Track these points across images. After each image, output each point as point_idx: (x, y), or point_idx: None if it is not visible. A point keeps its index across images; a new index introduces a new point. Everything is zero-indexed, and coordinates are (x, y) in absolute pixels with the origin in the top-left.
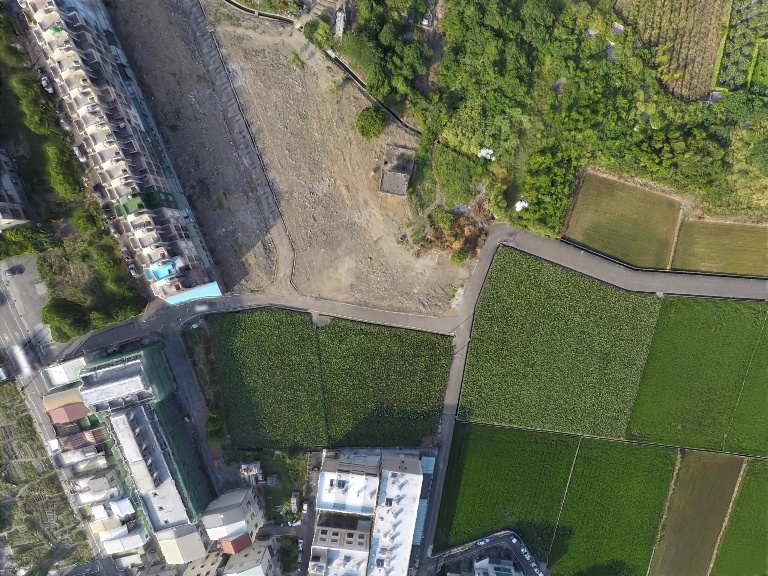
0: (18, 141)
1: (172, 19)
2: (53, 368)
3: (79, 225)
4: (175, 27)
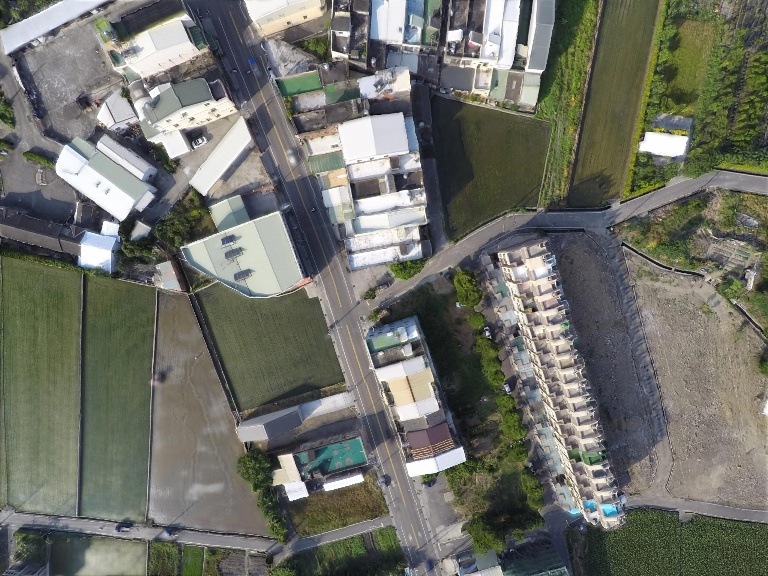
0: (451, 377)
1: (601, 277)
2: (471, 574)
3: (518, 458)
4: (605, 284)
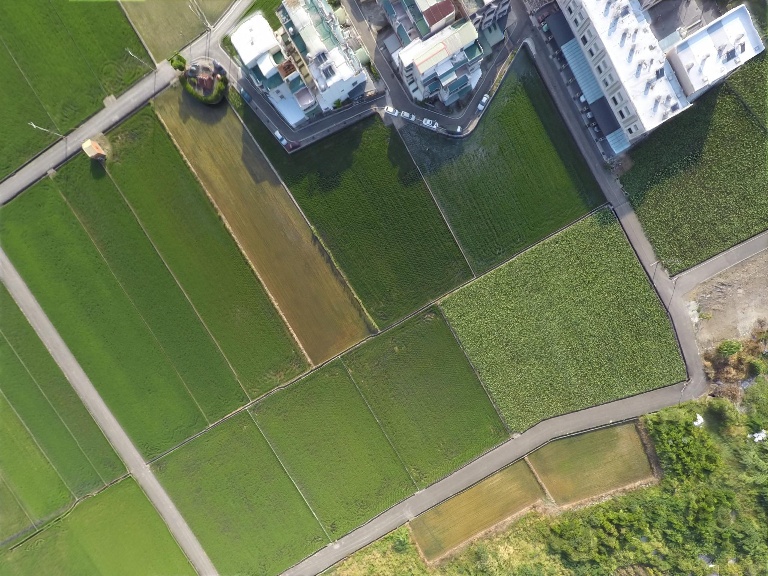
0: None
1: None
2: None
3: None
4: None
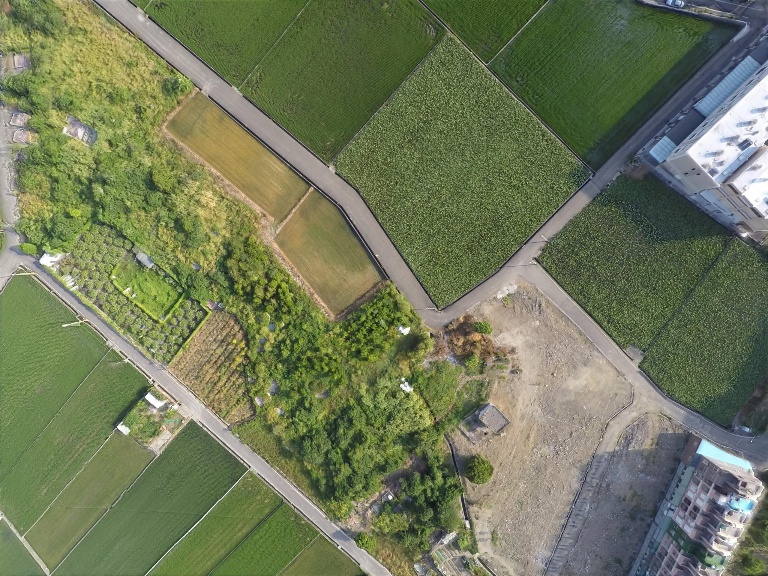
0: None
1: None
2: None
3: (761, 567)
4: None
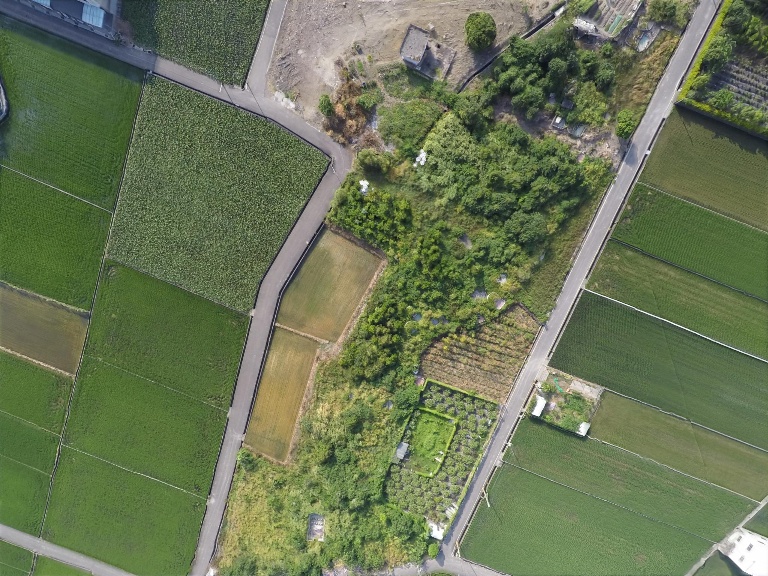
0: None
1: None
2: None
3: None
4: None
